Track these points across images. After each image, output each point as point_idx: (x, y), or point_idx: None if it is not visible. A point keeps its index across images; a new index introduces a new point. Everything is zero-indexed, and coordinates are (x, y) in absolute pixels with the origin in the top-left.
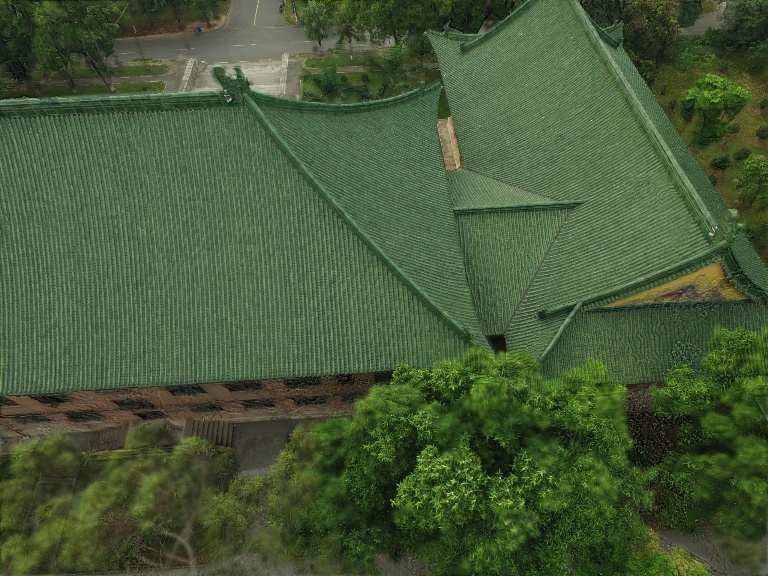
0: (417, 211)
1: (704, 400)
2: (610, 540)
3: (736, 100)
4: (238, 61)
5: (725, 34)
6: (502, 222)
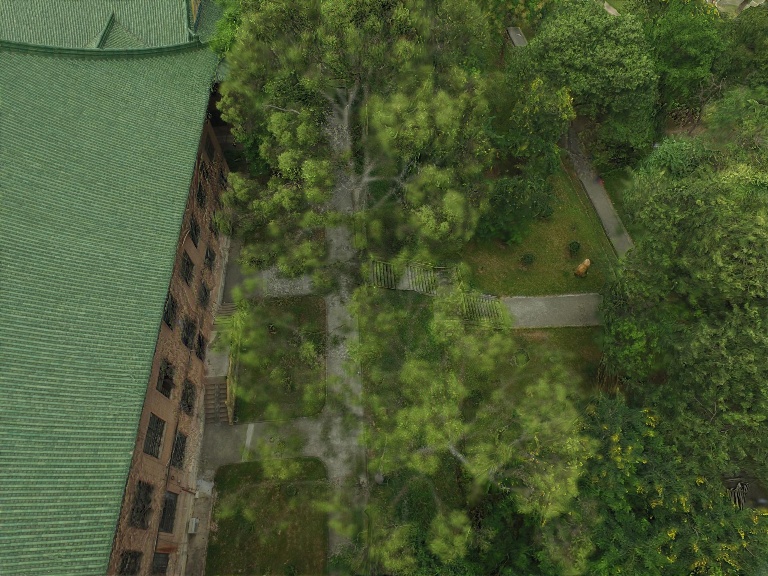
0: None
1: None
2: None
3: None
4: None
5: None
6: None
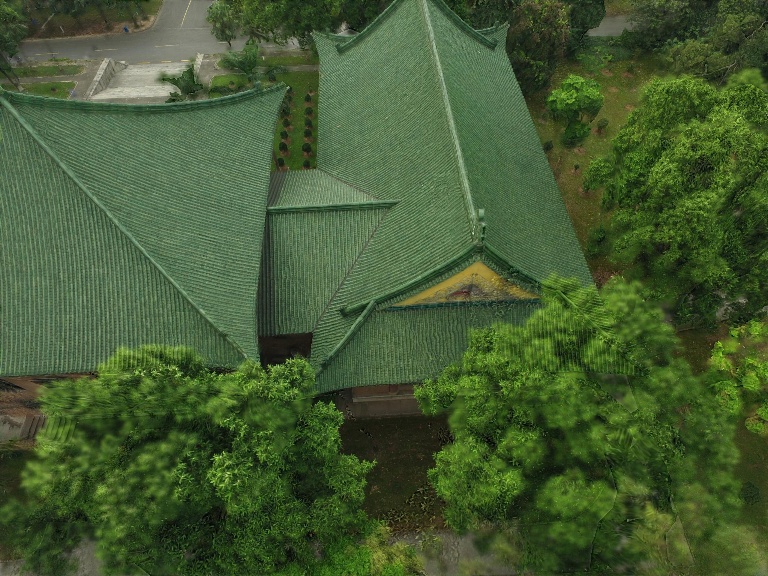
0: (218, 210)
1: (449, 397)
2: (326, 534)
3: (587, 101)
4: (159, 61)
5: (634, 35)
6: (320, 221)
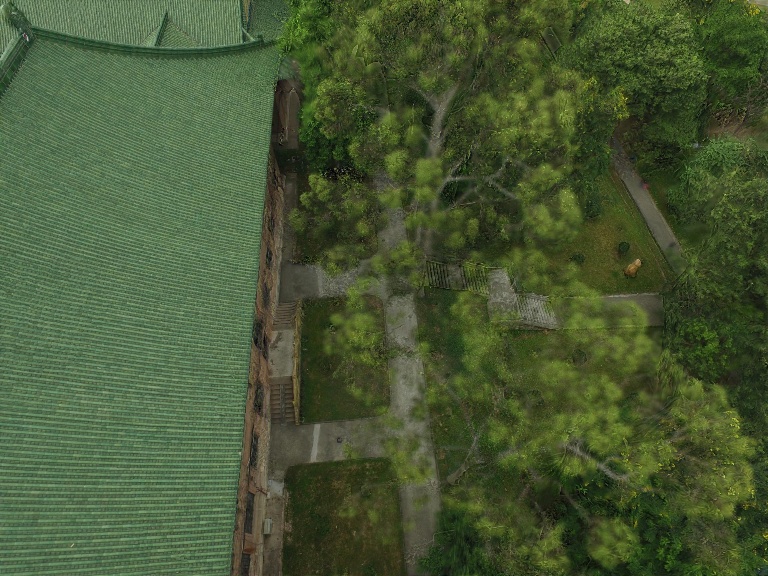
0: None
1: None
2: None
3: None
4: None
5: None
6: None
